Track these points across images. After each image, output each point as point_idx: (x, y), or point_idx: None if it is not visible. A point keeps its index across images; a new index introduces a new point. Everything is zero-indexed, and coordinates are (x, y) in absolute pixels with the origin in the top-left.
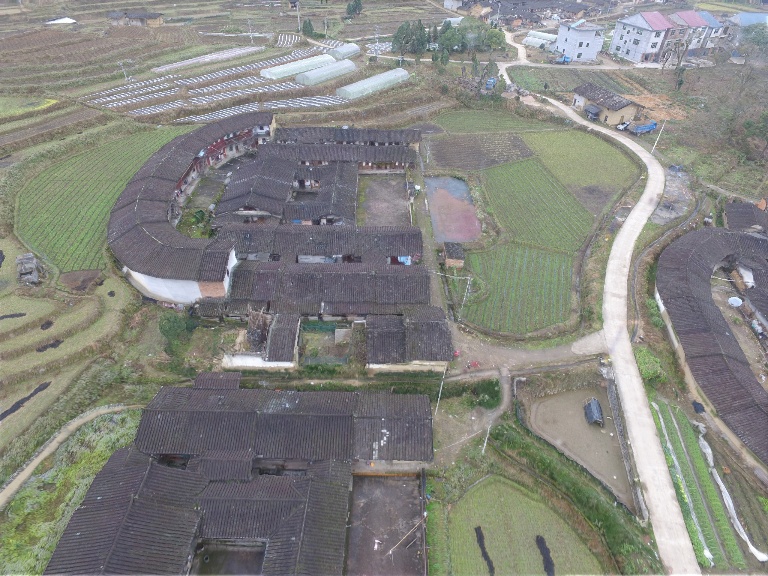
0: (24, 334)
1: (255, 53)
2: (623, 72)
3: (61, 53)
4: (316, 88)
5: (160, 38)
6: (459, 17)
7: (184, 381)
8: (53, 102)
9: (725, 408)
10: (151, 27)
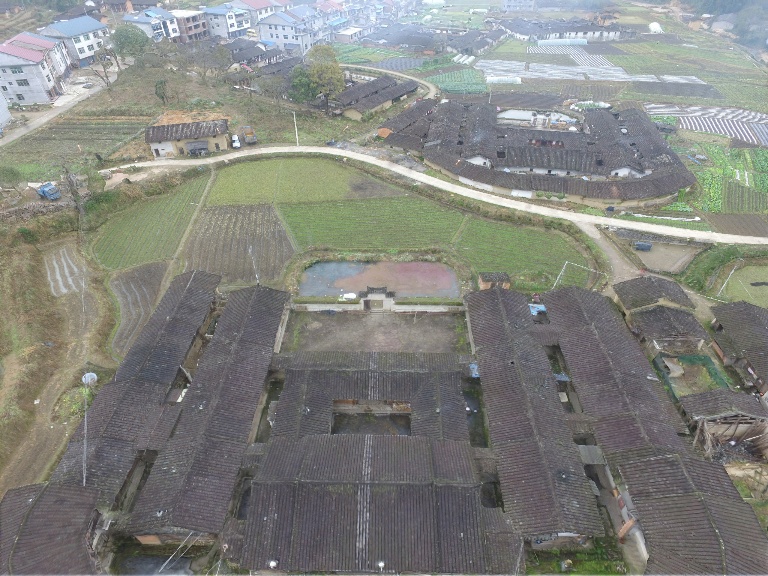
0: None
1: None
2: (70, 115)
3: None
4: None
5: None
6: None
7: None
8: None
9: (625, 195)
10: None
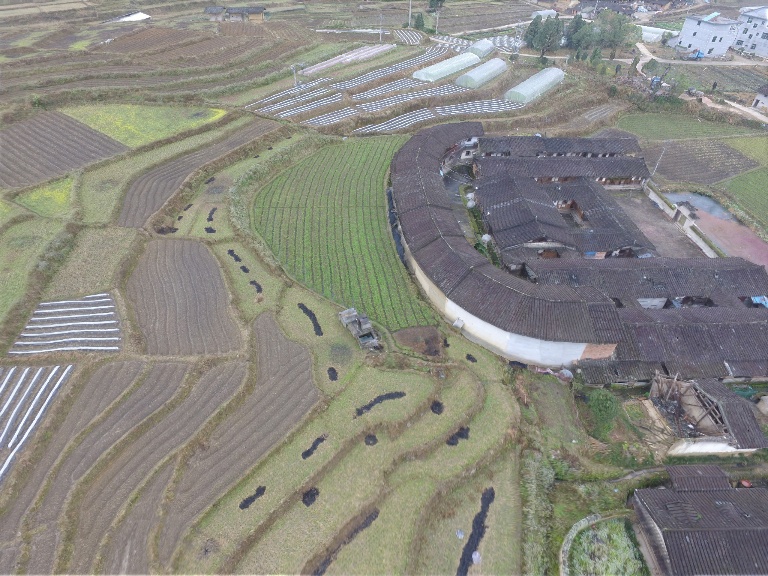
0: (419, 421)
1: (391, 52)
2: (763, 68)
3: (193, 54)
4: (483, 91)
5: (277, 35)
6: (548, 10)
7: (626, 474)
8: (221, 112)
9: None
10: (255, 23)
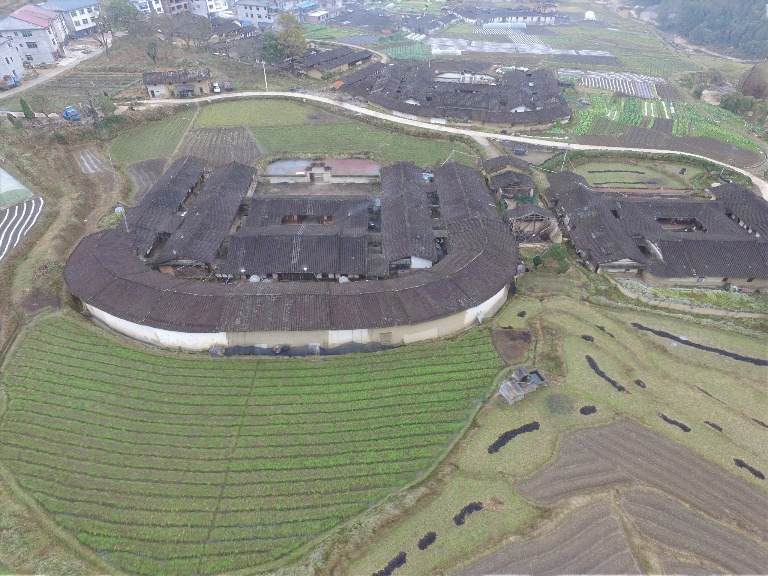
0: None
1: None
2: (75, 71)
3: None
4: None
5: None
6: None
7: None
8: None
9: (514, 120)
10: None
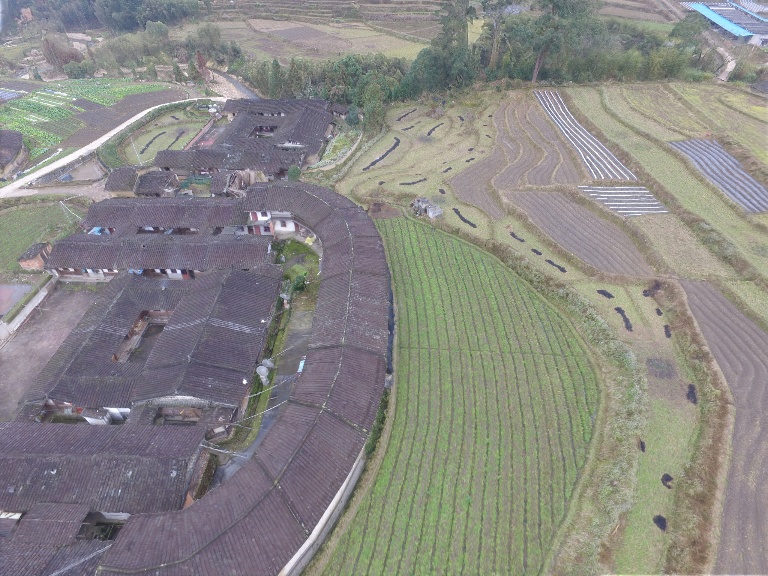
0: None
1: None
2: None
3: None
4: None
5: None
6: None
7: None
8: None
9: None
10: None
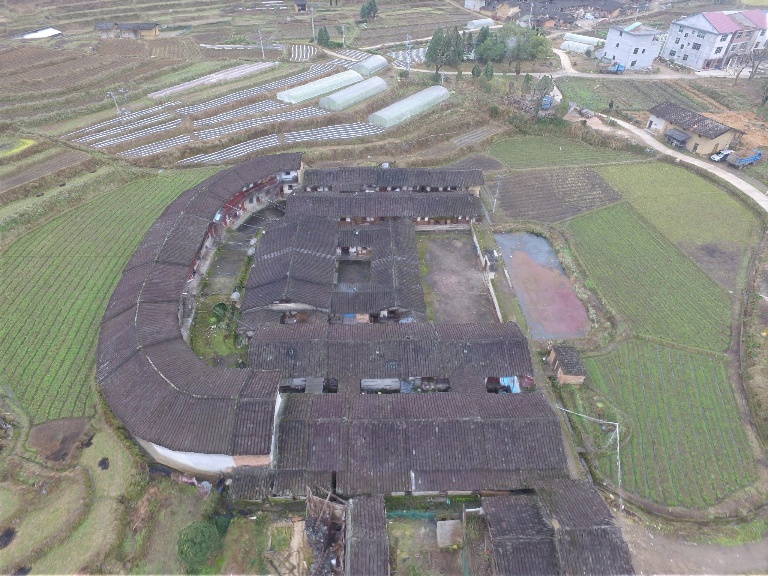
0: None
1: (268, 70)
2: (686, 82)
3: (40, 77)
4: (345, 114)
5: (157, 53)
6: (485, 19)
7: None
8: (29, 143)
9: None
10: (146, 39)
